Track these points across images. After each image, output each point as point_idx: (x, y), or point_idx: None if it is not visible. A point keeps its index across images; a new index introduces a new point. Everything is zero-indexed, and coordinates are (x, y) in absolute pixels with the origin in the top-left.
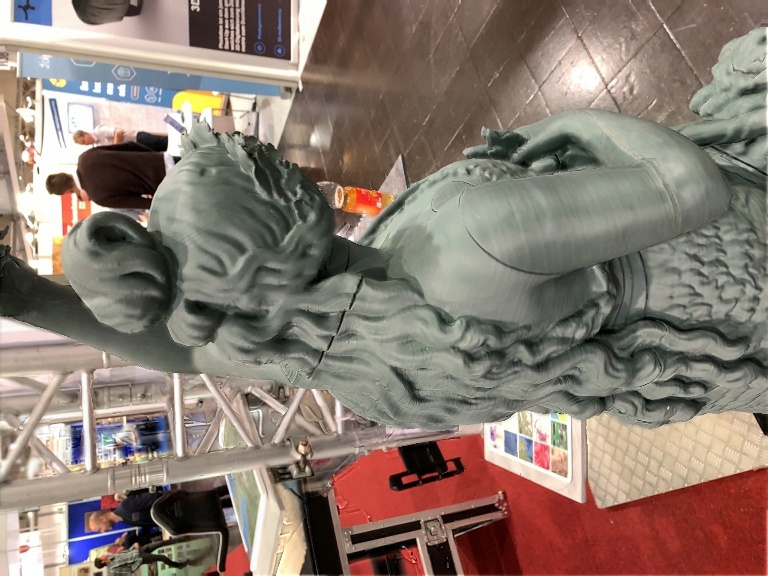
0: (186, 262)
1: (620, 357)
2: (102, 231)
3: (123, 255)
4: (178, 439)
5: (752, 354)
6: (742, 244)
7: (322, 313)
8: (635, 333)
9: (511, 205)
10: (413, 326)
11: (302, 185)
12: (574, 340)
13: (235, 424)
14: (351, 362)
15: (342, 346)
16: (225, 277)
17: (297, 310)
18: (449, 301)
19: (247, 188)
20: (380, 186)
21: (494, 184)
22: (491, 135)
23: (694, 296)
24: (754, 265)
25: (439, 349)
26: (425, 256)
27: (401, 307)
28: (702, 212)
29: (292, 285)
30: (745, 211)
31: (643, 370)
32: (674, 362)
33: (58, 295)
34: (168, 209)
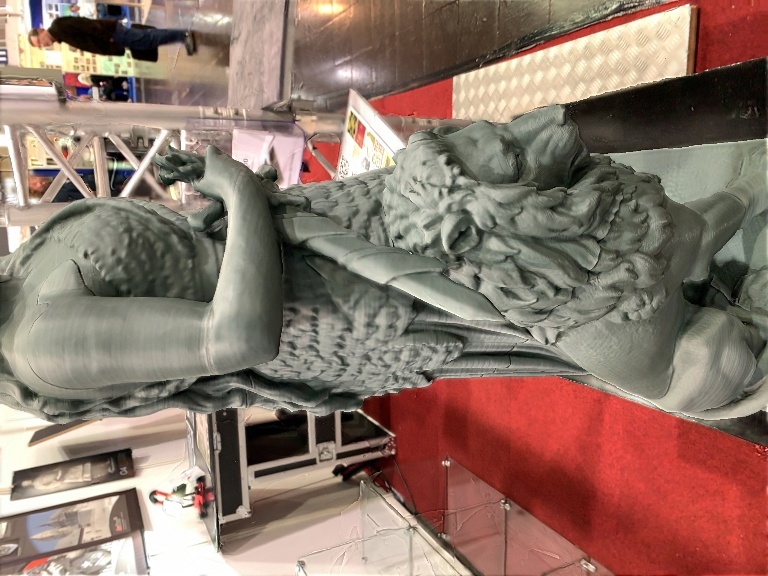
0: None
1: (213, 397)
2: None
3: None
4: (19, 189)
5: (342, 392)
6: (334, 339)
7: None
8: (229, 384)
9: (64, 350)
10: (6, 391)
11: None
12: (160, 397)
13: (76, 184)
14: None
15: None
16: None
17: None
18: (30, 386)
19: None
20: None
21: (66, 315)
22: (167, 164)
23: (284, 367)
24: (344, 351)
25: None
26: (11, 352)
27: None
28: (240, 367)
29: None
30: (349, 312)
31: (233, 404)
32: (262, 401)
33: None
34: None
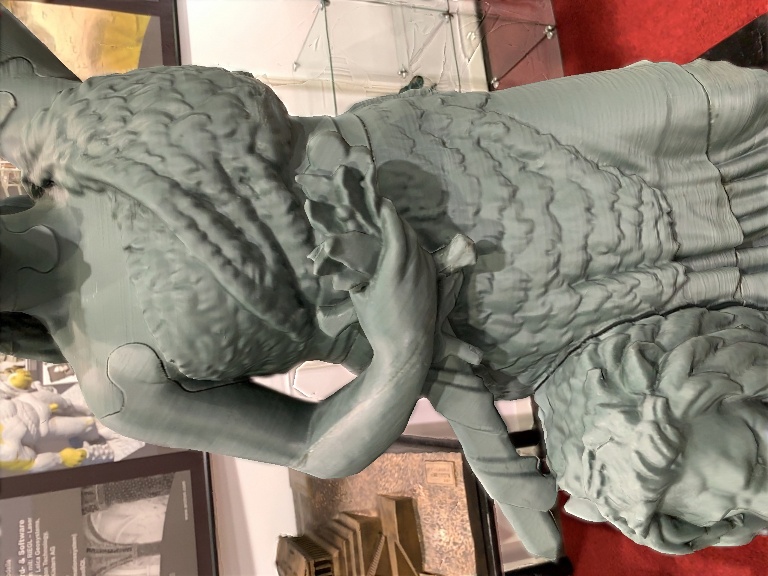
0: None
1: None
2: None
3: None
4: None
5: None
6: None
7: None
8: None
9: None
10: None
11: None
12: None
13: None
14: None
15: None
16: None
17: None
18: None
19: None
20: None
21: (146, 426)
22: None
23: None
24: None
25: None
26: None
27: None
28: None
29: None
30: None
31: None
32: None
33: None
34: None
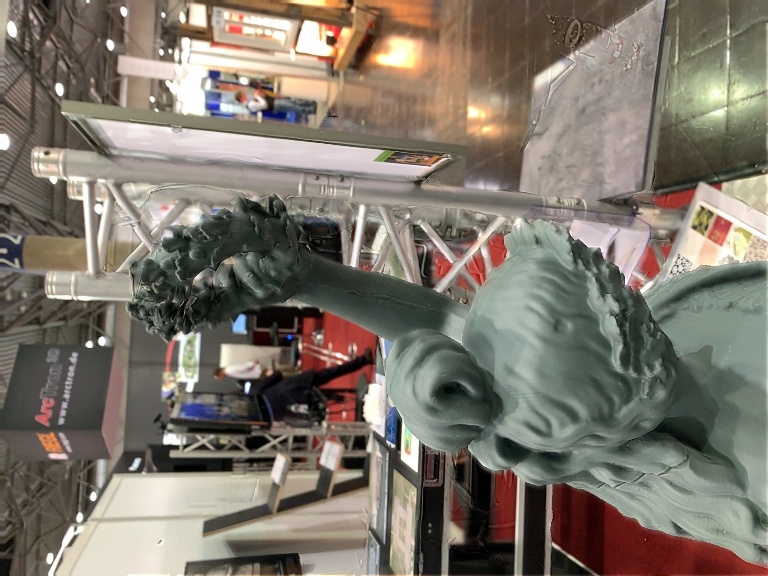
0: (512, 412)
1: None
2: (443, 387)
3: (459, 414)
4: None
5: None
6: None
7: (626, 467)
8: None
9: None
10: (721, 512)
11: (663, 359)
12: None
13: (405, 268)
14: (631, 499)
15: (630, 489)
16: (548, 438)
17: (603, 463)
18: None
19: (602, 356)
20: (623, 19)
21: None
22: None
23: None
24: None
25: (738, 539)
26: None
27: (717, 494)
28: None
29: (609, 446)
30: None
31: None
32: None
33: (327, 277)
34: (507, 355)
